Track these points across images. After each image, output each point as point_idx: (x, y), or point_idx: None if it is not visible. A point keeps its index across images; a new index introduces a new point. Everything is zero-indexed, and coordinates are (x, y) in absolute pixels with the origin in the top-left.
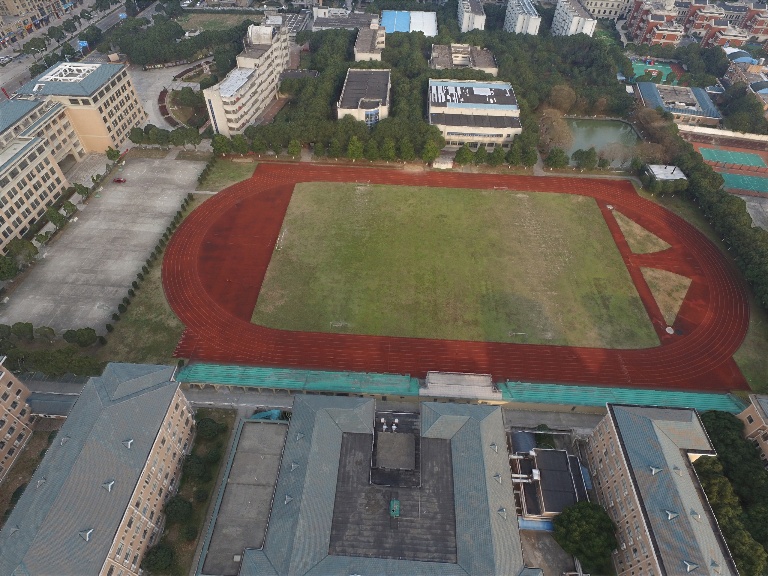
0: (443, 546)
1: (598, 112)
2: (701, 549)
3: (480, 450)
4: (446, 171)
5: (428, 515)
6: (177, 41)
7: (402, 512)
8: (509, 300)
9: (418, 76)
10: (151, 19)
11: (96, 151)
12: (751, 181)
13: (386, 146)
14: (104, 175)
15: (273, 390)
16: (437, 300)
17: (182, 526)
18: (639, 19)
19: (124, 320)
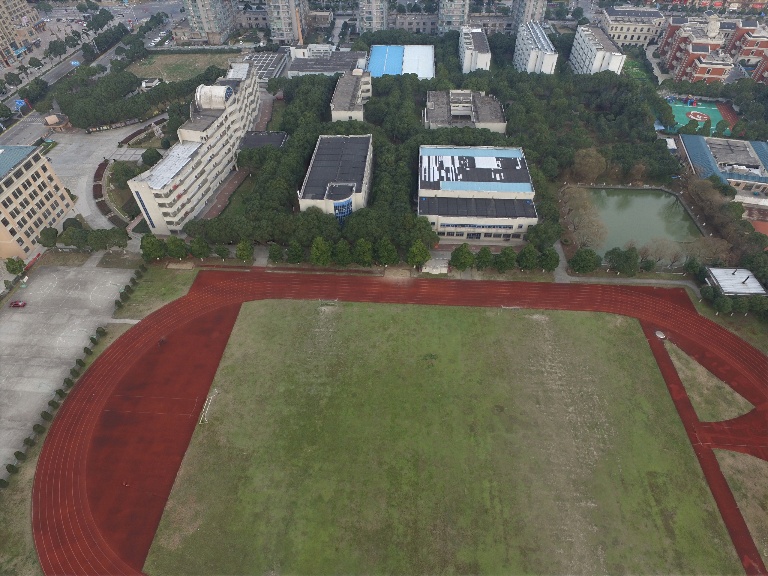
0: None
1: (633, 178)
2: None
3: None
4: (439, 278)
5: None
6: (134, 92)
7: None
8: (524, 520)
9: (407, 139)
10: (111, 64)
11: (1, 257)
12: None
13: (360, 249)
14: None
15: None
16: (418, 521)
17: None
18: (675, 48)
19: None
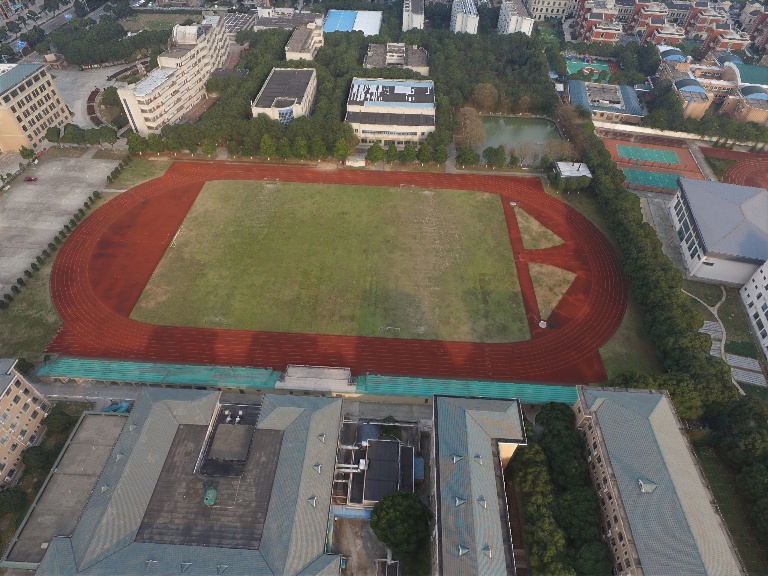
0: (250, 533)
1: (524, 110)
2: (476, 534)
3: (305, 440)
4: (358, 169)
5: (243, 503)
6: None
7: (218, 501)
8: (390, 295)
9: None
10: None
11: (14, 150)
12: (660, 178)
13: (297, 144)
14: (16, 174)
15: (133, 384)
16: (319, 296)
17: (14, 516)
18: (582, 18)
19: (4, 316)
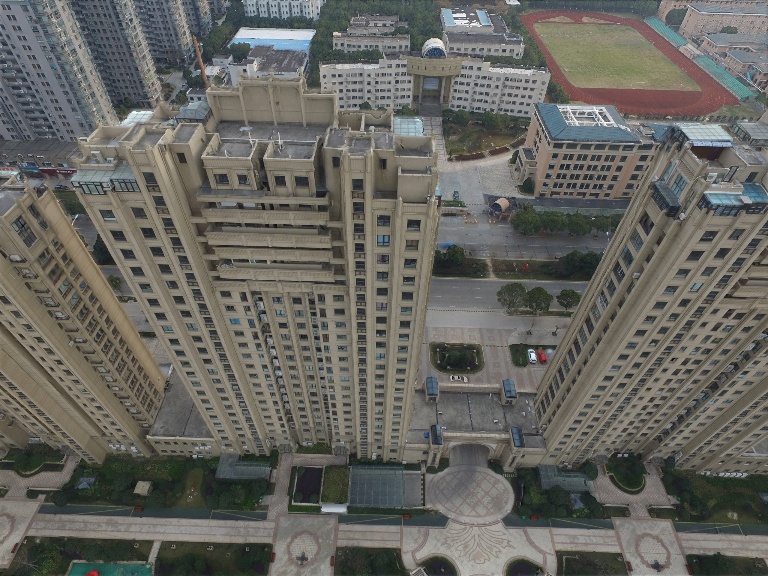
0: None
1: None
2: None
3: (731, 34)
4: None
5: None
6: None
7: None
8: None
9: None
10: None
11: None
12: None
13: None
14: None
15: None
16: None
17: None
18: None
19: None
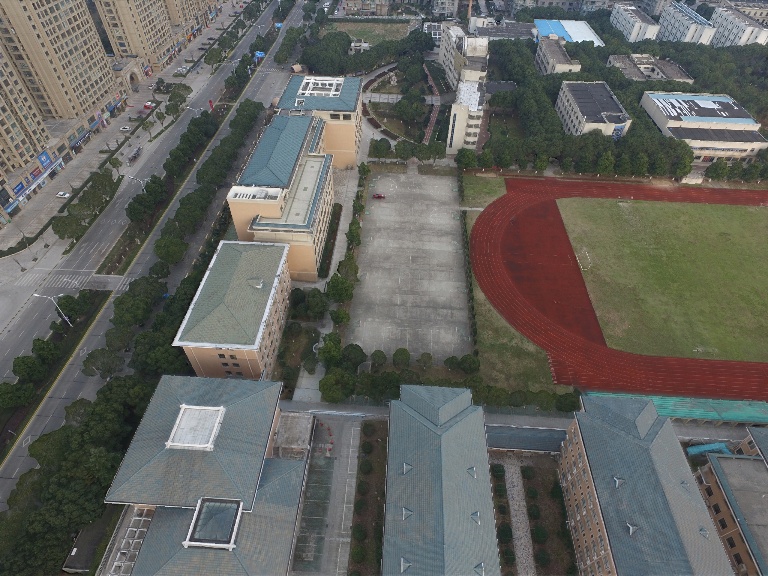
0: None
1: None
2: None
3: None
4: (697, 186)
5: None
6: None
7: None
8: None
9: None
10: None
11: (336, 166)
12: None
13: (641, 161)
14: None
15: (687, 420)
16: None
17: None
18: None
19: (480, 344)
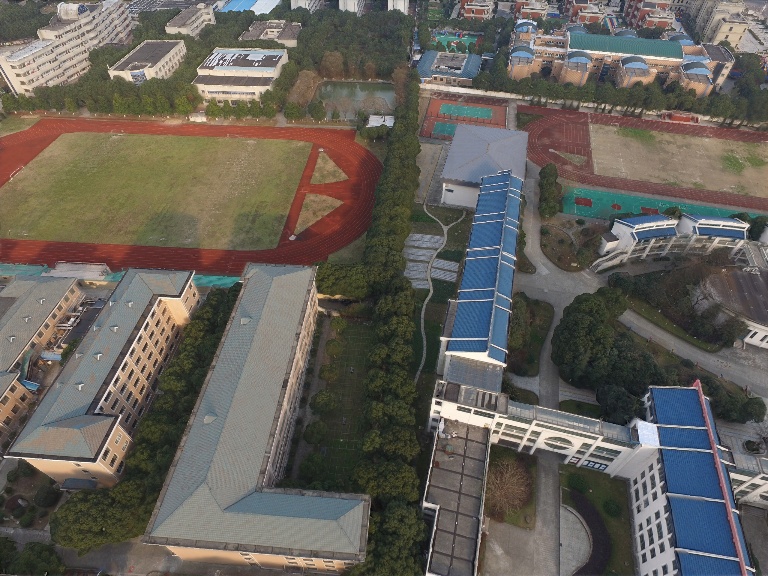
0: None
1: (374, 76)
2: (93, 345)
3: (24, 301)
4: (200, 124)
5: None
6: None
7: None
8: (175, 217)
9: None
10: None
11: None
12: None
13: (143, 102)
14: None
15: None
16: (115, 217)
17: None
18: None
19: None
